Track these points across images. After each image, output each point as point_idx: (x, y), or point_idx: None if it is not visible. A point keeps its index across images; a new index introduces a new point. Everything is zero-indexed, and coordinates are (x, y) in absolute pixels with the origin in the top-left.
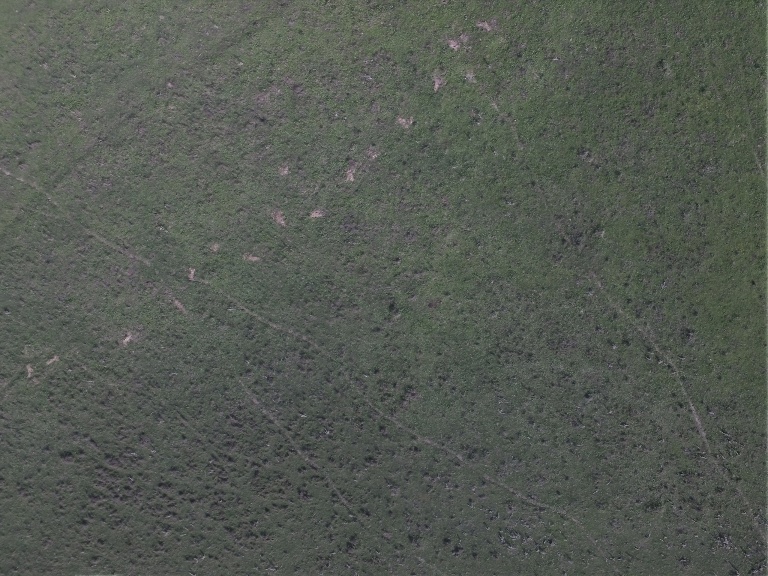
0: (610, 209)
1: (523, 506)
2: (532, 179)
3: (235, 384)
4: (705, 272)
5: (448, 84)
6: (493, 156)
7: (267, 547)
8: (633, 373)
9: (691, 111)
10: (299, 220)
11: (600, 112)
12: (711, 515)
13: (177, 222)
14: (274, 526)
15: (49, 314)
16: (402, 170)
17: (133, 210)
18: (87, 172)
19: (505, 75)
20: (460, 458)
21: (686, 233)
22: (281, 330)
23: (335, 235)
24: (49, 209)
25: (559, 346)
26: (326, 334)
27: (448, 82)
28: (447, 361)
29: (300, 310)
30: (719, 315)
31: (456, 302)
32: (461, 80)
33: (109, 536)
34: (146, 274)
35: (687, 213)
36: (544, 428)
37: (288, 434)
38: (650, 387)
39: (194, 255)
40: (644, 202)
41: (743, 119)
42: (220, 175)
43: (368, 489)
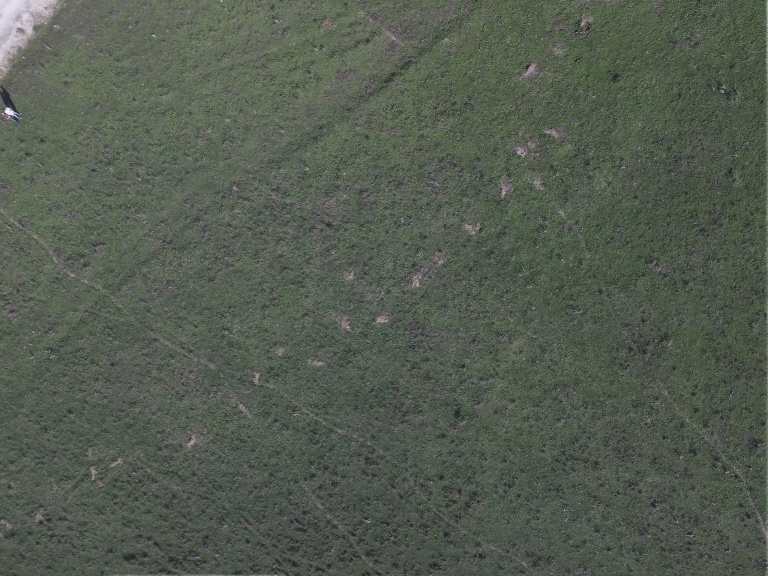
0: (678, 318)
1: None
2: (599, 287)
3: (299, 489)
4: None
5: (515, 191)
6: (560, 263)
7: None
8: (700, 483)
9: (760, 221)
10: (364, 325)
11: (668, 221)
12: None
13: (242, 326)
14: None
15: (113, 417)
16: (468, 276)
17: (198, 313)
18: (152, 275)
19: (573, 183)
20: (525, 565)
21: (754, 343)
22: (346, 435)
23: (401, 341)
24: (114, 312)
25: (625, 455)
26: (391, 440)
27: (515, 189)
28: (512, 468)
29: (365, 415)
30: None
31: (522, 409)
32: (528, 187)
33: None
34: (211, 378)
35: (756, 324)
36: (610, 536)
37: (352, 539)
38: (717, 497)
39: (259, 359)
40: (712, 312)
41: None
42: (285, 279)
43: None
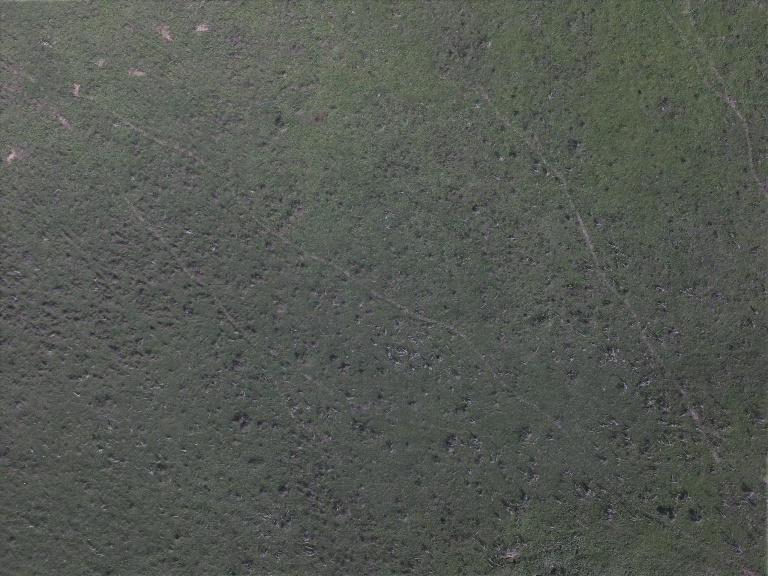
0: (497, 20)
1: (410, 321)
2: None
3: (120, 201)
4: (592, 82)
5: None
6: None
7: (152, 366)
8: (520, 186)
9: None
10: (185, 34)
11: None
12: (599, 328)
13: (62, 38)
14: (159, 345)
15: None
16: None
17: (17, 26)
18: None
19: None
20: (347, 274)
21: (573, 43)
22: (167, 146)
23: (221, 49)
24: None
25: (446, 159)
26: (212, 149)
27: None
28: (334, 176)
29: (186, 125)
30: (606, 126)
31: (343, 116)
32: None
33: None
34: (30, 90)
35: (573, 22)
36: (431, 242)
37: (174, 251)
38: (537, 199)
39: (79, 71)
40: (531, 12)
41: None
42: None
43: (254, 306)
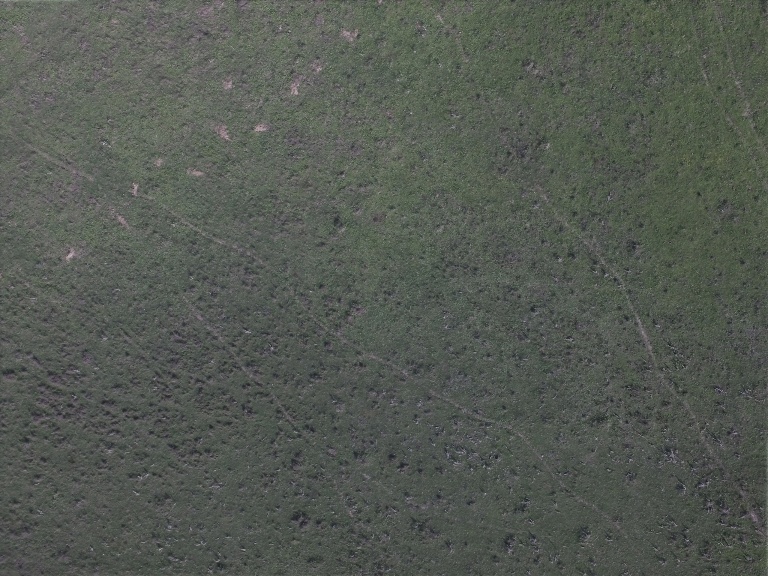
0: (555, 121)
1: (469, 421)
2: (477, 91)
3: (179, 300)
4: (651, 184)
5: None
6: (438, 69)
7: (211, 465)
8: (579, 286)
9: (636, 22)
10: (243, 134)
11: (545, 23)
12: (657, 429)
13: (120, 137)
14: (218, 443)
15: None
16: (347, 83)
17: (76, 125)
18: (29, 87)
19: None
20: (405, 374)
21: (632, 145)
22: (225, 245)
23: (279, 149)
24: None
25: (505, 260)
26: (270, 249)
27: None
28: (392, 276)
29: (244, 225)
30: (665, 227)
31: (401, 216)
32: None
33: (52, 454)
34: (89, 190)
35: (632, 124)
36: (490, 343)
37: (232, 350)
38: (596, 300)
39: (137, 170)
40: (589, 114)
41: (688, 29)
42: (164, 89)
43: (313, 405)
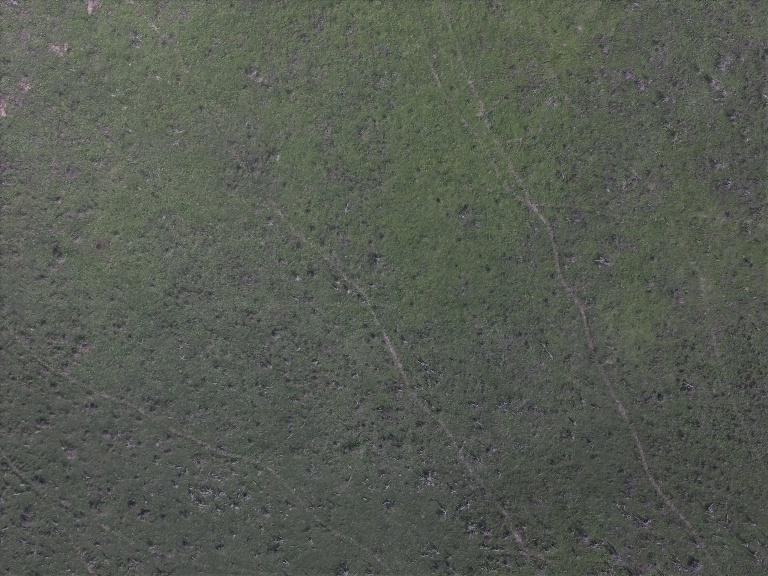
0: (284, 131)
1: (213, 458)
2: (200, 104)
3: None
4: (388, 192)
5: (103, 6)
6: (157, 82)
7: None
8: (321, 305)
9: (362, 23)
10: None
11: (267, 29)
12: (413, 451)
13: None
14: None
15: None
16: (59, 102)
17: None
18: None
19: None
20: (142, 412)
21: (366, 152)
22: None
23: None
24: None
25: (241, 282)
26: None
27: (103, 4)
28: (121, 307)
29: None
30: (407, 237)
31: (126, 242)
32: (117, 1)
33: None
34: None
35: (365, 131)
36: (230, 372)
37: None
38: (340, 319)
39: None
40: (320, 122)
41: (416, 29)
42: None
43: (42, 454)
